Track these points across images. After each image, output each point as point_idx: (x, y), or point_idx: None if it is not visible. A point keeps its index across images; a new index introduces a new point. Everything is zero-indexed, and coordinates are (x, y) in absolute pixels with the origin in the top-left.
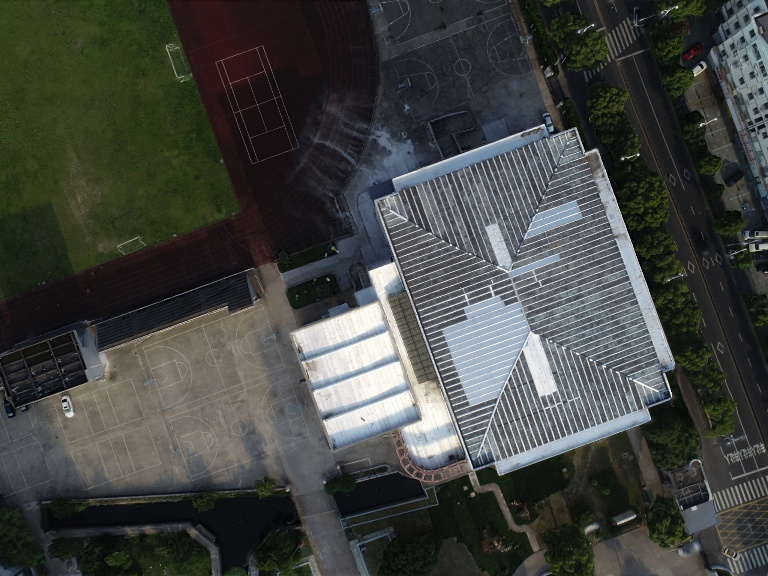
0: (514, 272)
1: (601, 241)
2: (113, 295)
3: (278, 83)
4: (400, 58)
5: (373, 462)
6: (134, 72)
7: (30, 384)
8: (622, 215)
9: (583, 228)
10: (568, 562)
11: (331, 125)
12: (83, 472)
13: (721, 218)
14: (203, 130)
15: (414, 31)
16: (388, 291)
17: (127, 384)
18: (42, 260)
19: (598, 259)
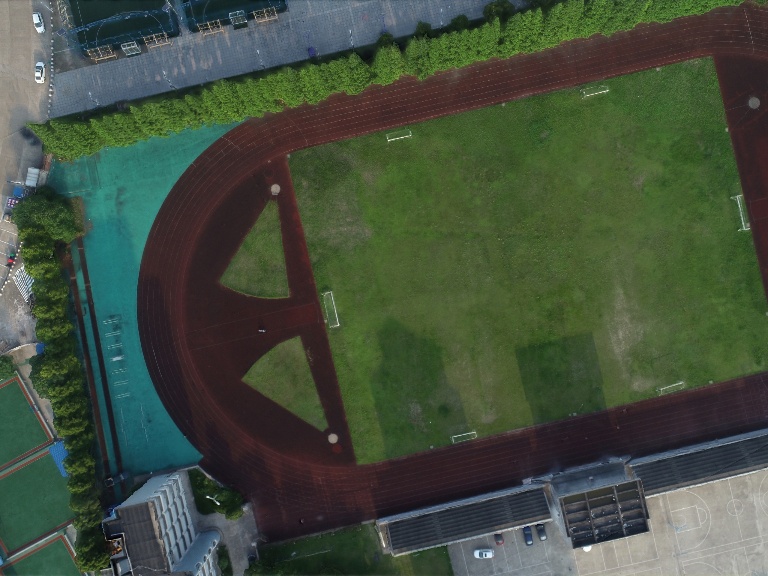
0: None
1: None
2: (642, 434)
3: None
4: None
5: None
6: (692, 215)
7: (587, 526)
8: None
9: None
10: None
11: None
12: None
13: None
14: (753, 281)
15: None
16: None
17: None
18: (576, 392)
19: None
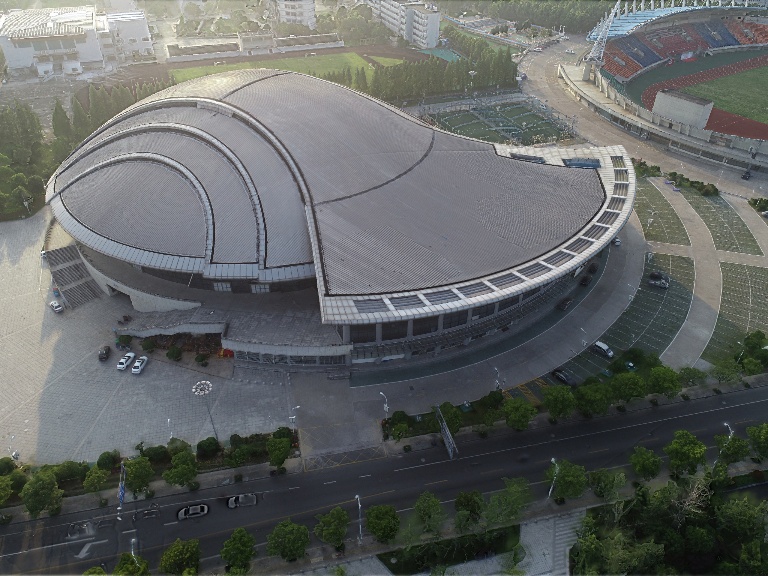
0: None
1: None
2: None
3: None
4: None
5: None
6: None
7: None
8: None
9: None
10: None
11: None
12: None
13: None
14: None
15: None
16: (104, 30)
17: None
18: None
19: None
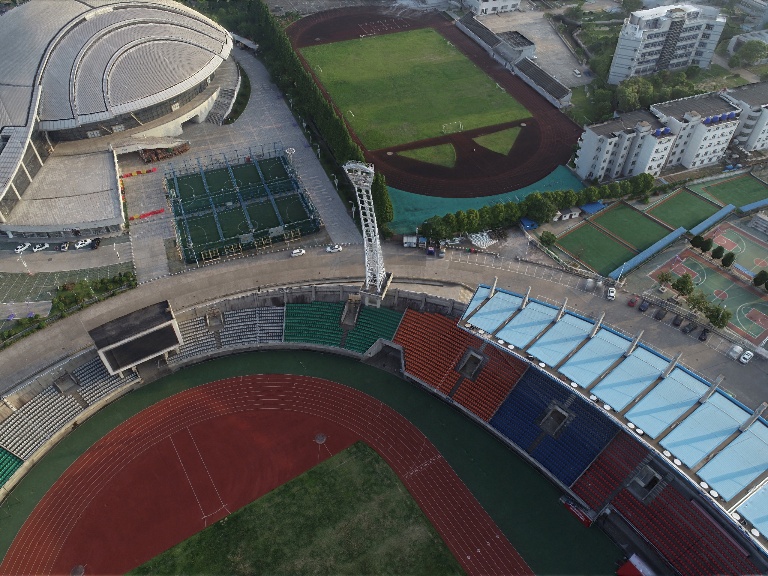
0: None
1: None
2: None
3: None
4: None
5: None
6: None
7: None
8: None
9: None
10: None
11: None
12: None
13: None
14: (396, 34)
15: None
16: None
17: None
18: None
19: None
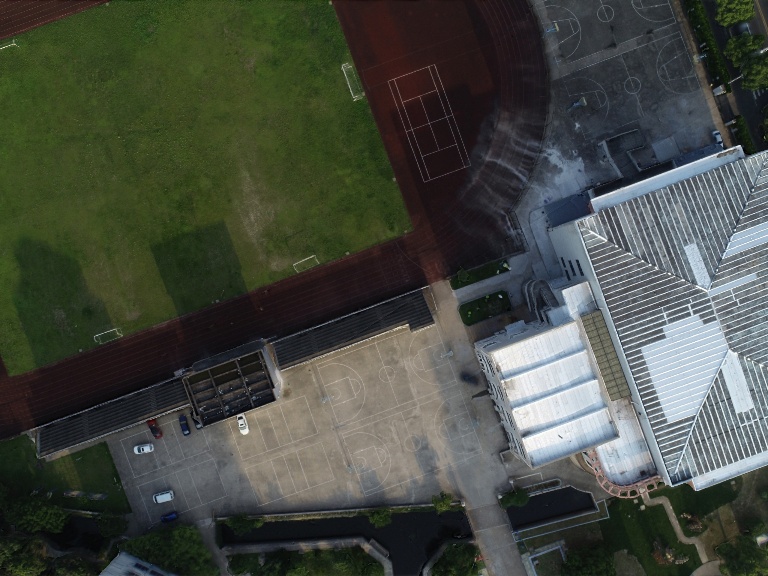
0: (713, 291)
1: None
2: (286, 313)
3: (450, 102)
4: (571, 76)
5: (544, 476)
6: (307, 91)
7: (217, 403)
8: None
9: None
10: (752, 574)
11: (502, 143)
12: (257, 488)
13: None
14: (376, 149)
15: (585, 50)
16: (581, 310)
17: (301, 401)
18: (216, 278)
19: None
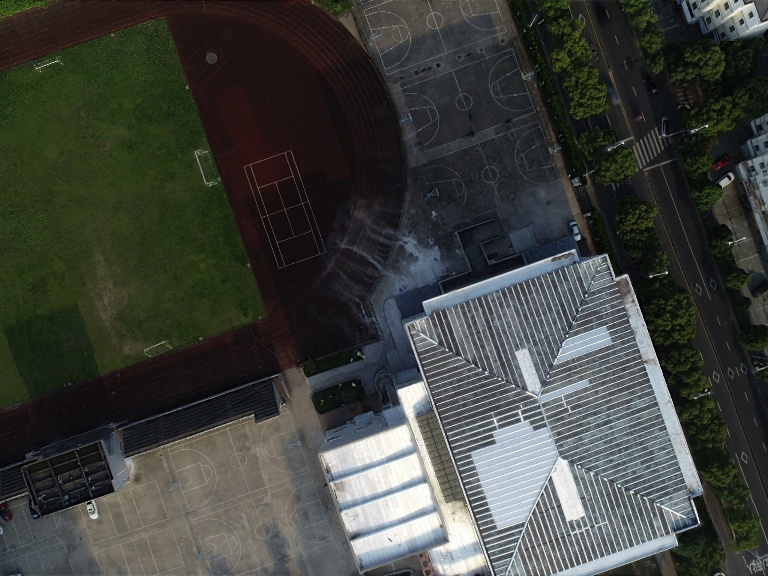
0: (543, 398)
1: (630, 367)
2: (139, 397)
3: (306, 188)
4: (428, 165)
5: (396, 567)
6: (162, 175)
7: (57, 492)
8: (649, 330)
9: (613, 354)
10: None
11: (358, 230)
12: (107, 573)
13: (748, 333)
14: (230, 234)
15: (442, 138)
16: (416, 410)
17: (152, 486)
18: (68, 361)
19: (627, 385)
